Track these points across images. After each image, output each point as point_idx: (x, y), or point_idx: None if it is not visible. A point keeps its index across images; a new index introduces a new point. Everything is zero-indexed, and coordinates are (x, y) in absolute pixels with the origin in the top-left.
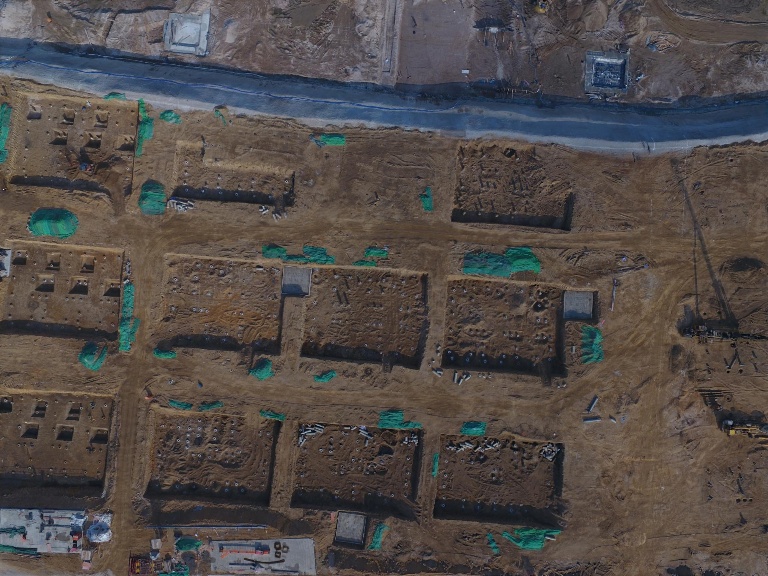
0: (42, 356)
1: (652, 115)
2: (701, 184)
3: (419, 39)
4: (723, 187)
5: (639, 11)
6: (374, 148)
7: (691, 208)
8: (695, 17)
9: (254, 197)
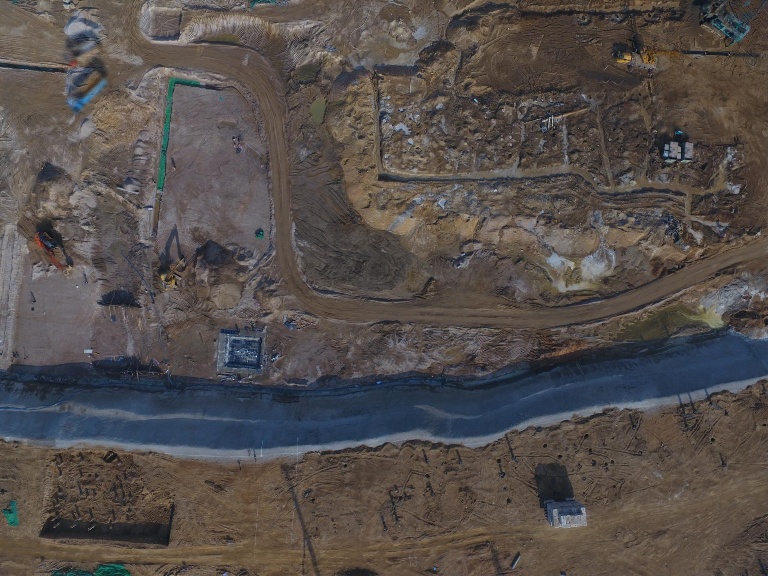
0: None
1: (287, 398)
2: (312, 492)
3: (38, 316)
4: (336, 494)
5: (271, 291)
6: None
7: (301, 517)
8: (334, 295)
9: None
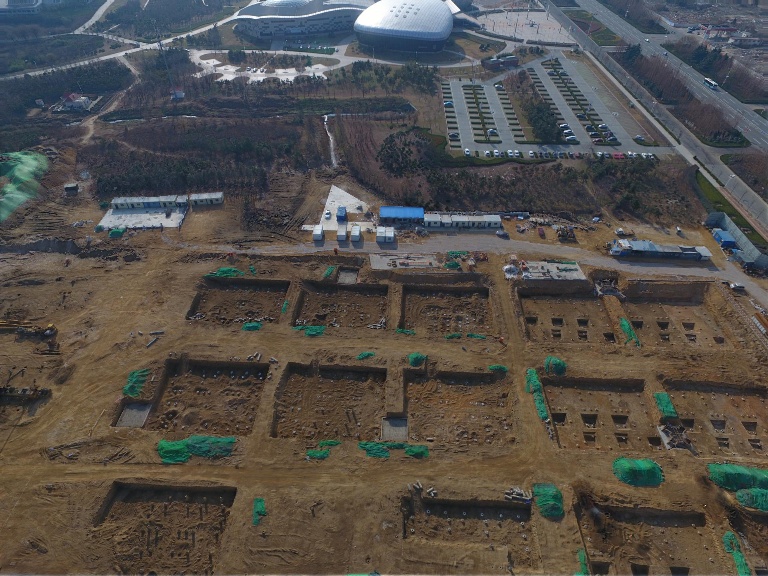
0: (595, 365)
1: None
2: None
3: None
4: None
5: None
6: (312, 572)
7: None
8: None
9: (446, 511)
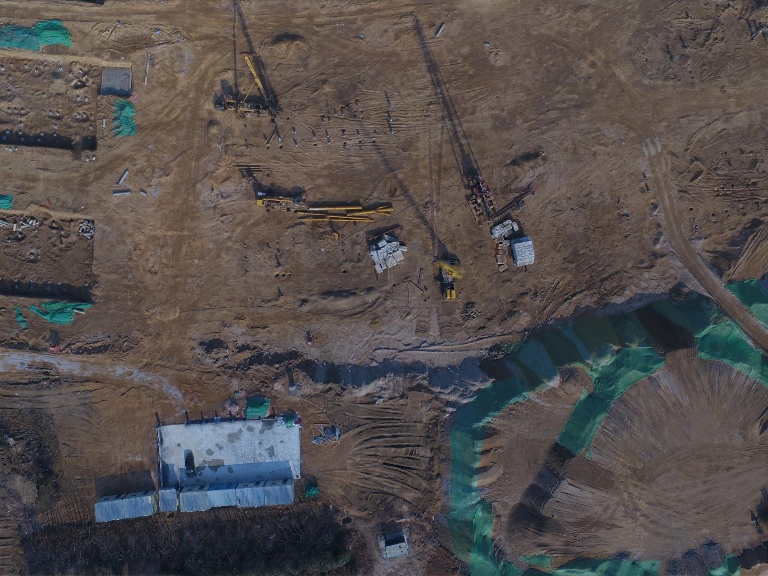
0: None
1: None
2: None
3: None
4: None
5: None
6: None
7: None
8: None
9: None
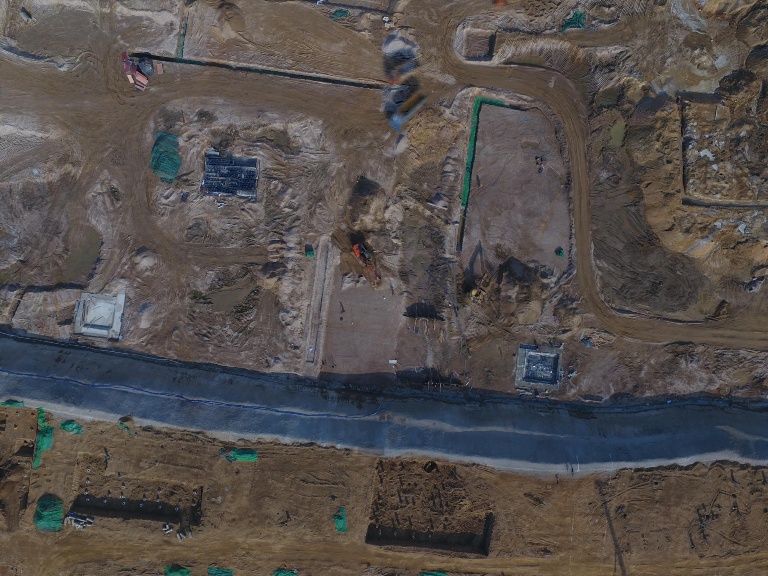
0: None
1: (582, 414)
2: (624, 507)
3: (346, 326)
4: (646, 510)
5: (574, 309)
6: (288, 465)
7: (613, 532)
8: (631, 315)
9: (160, 508)
